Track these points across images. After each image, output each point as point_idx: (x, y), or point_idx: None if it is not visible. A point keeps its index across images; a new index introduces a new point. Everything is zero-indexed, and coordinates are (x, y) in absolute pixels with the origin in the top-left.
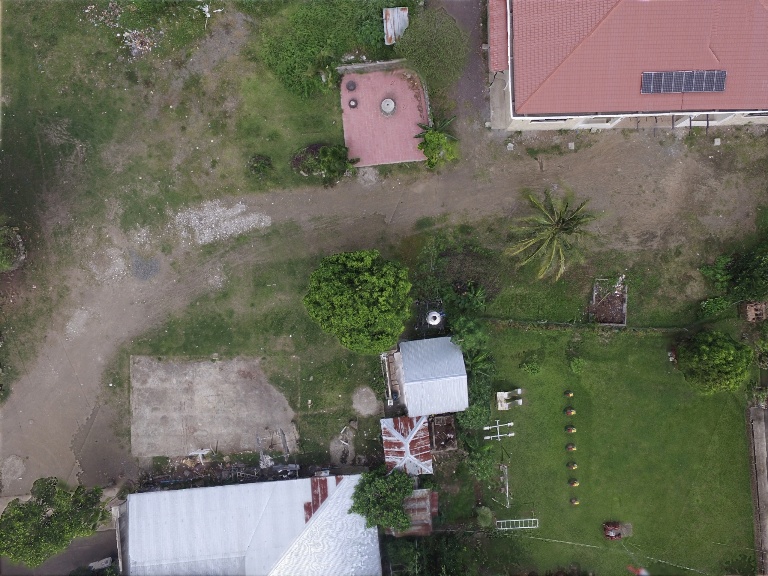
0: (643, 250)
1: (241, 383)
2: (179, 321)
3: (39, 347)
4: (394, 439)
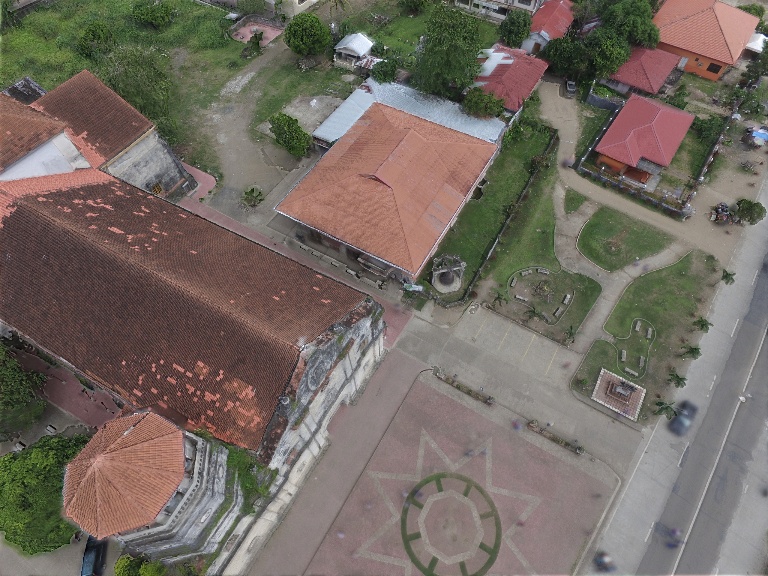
0: (368, 8)
1: (302, 104)
2: (258, 110)
3: (215, 155)
4: (365, 62)
